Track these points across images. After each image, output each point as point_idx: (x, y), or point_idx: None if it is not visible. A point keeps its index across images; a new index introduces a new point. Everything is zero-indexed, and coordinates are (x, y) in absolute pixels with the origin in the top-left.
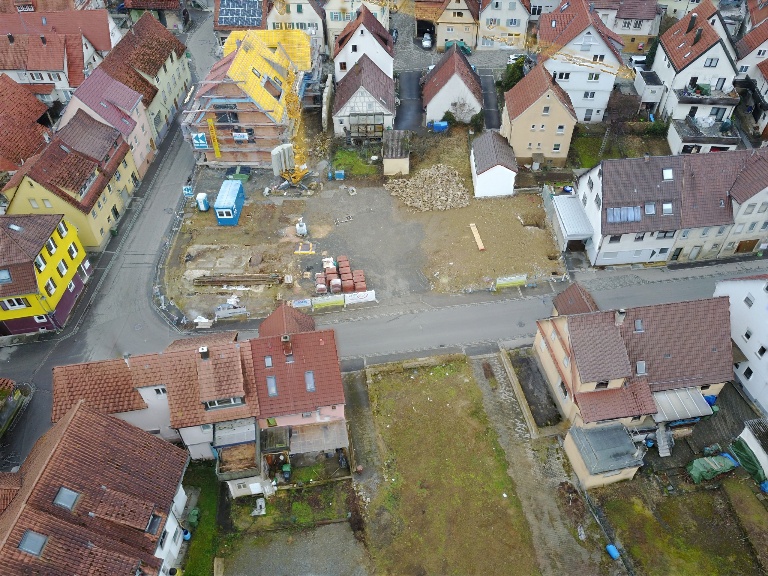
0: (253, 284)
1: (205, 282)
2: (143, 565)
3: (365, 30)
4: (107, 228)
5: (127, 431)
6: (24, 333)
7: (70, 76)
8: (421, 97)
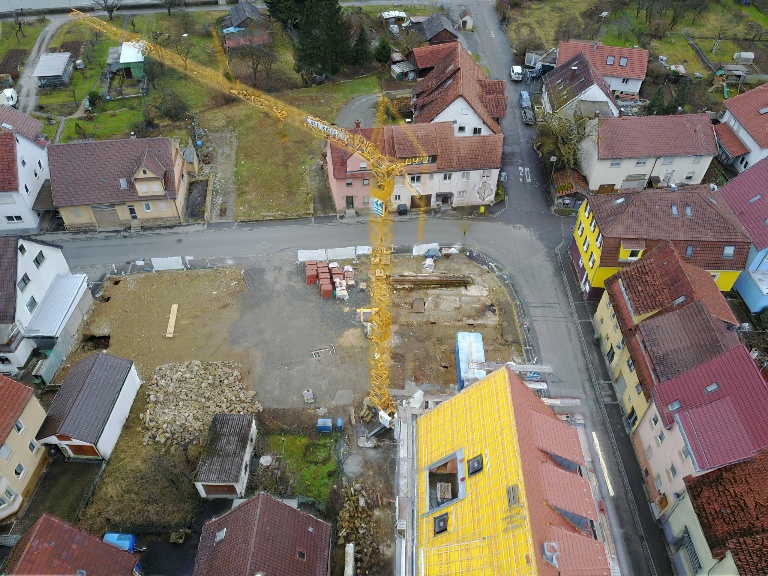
0: None
1: None
2: None
3: None
4: None
5: None
6: None
7: None
8: None
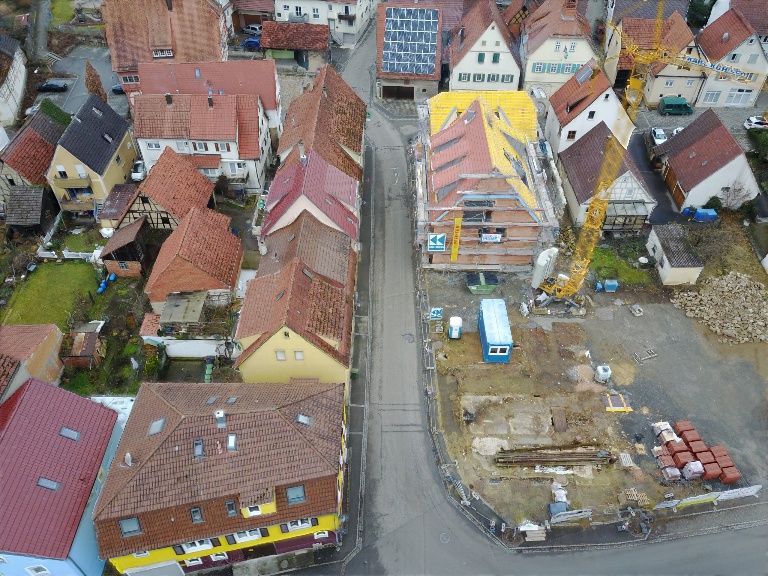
0: (576, 464)
1: (513, 462)
2: None
3: (612, 94)
4: None
5: None
6: (292, 551)
7: (240, 146)
8: (654, 170)
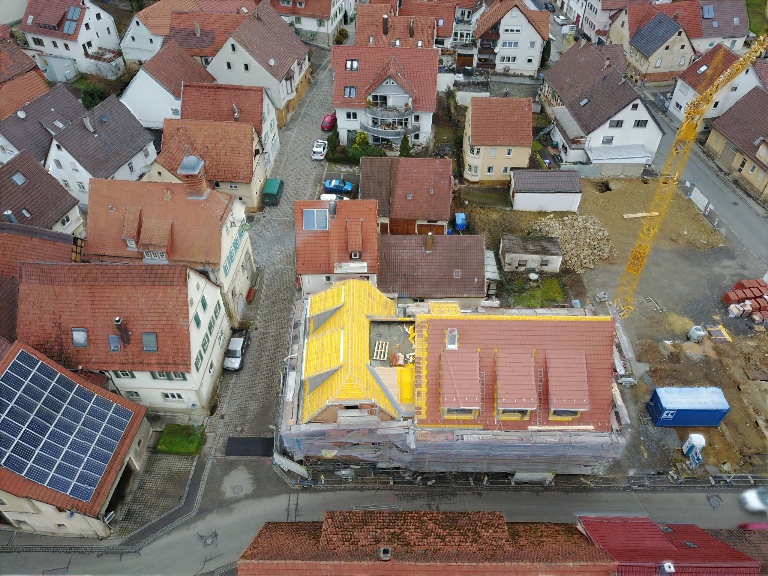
0: None
1: None
2: None
3: None
4: None
5: None
6: None
7: None
8: None
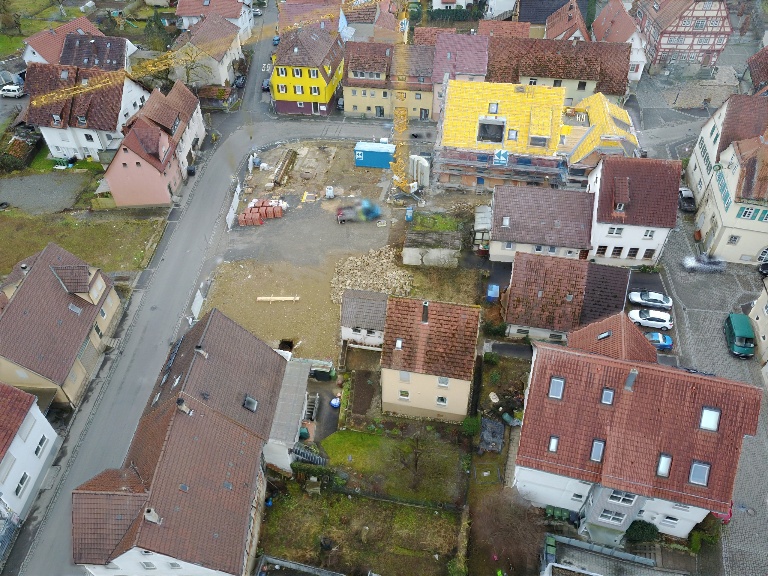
0: None
1: None
2: (63, 121)
3: None
4: (362, 111)
5: (117, 98)
6: None
7: None
8: None
